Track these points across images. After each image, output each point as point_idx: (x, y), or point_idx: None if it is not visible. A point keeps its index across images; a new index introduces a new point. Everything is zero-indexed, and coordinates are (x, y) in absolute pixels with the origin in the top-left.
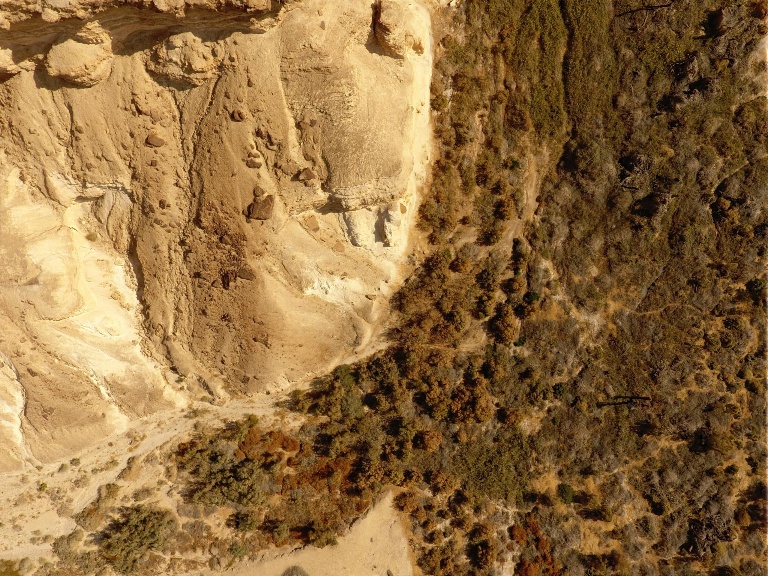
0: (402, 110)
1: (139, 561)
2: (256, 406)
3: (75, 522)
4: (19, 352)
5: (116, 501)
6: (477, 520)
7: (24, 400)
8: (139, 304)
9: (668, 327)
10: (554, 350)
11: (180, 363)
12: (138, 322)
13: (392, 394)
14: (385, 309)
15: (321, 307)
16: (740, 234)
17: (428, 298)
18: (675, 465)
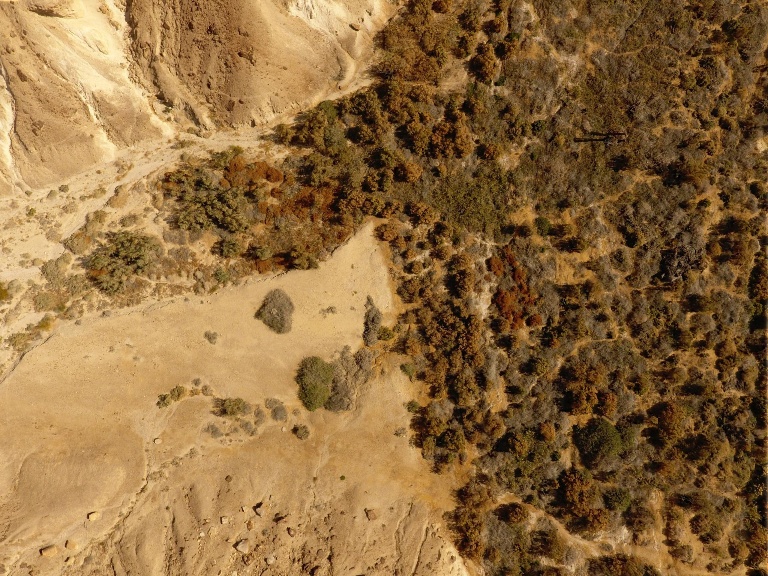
0: None
1: (125, 283)
2: (241, 139)
3: (63, 246)
4: (9, 47)
5: (103, 227)
6: (456, 252)
7: (14, 115)
8: (127, 26)
9: (645, 67)
10: (533, 86)
11: (167, 86)
12: (126, 46)
13: (374, 122)
14: (369, 47)
15: (305, 32)
16: None
17: (411, 32)
18: (649, 197)
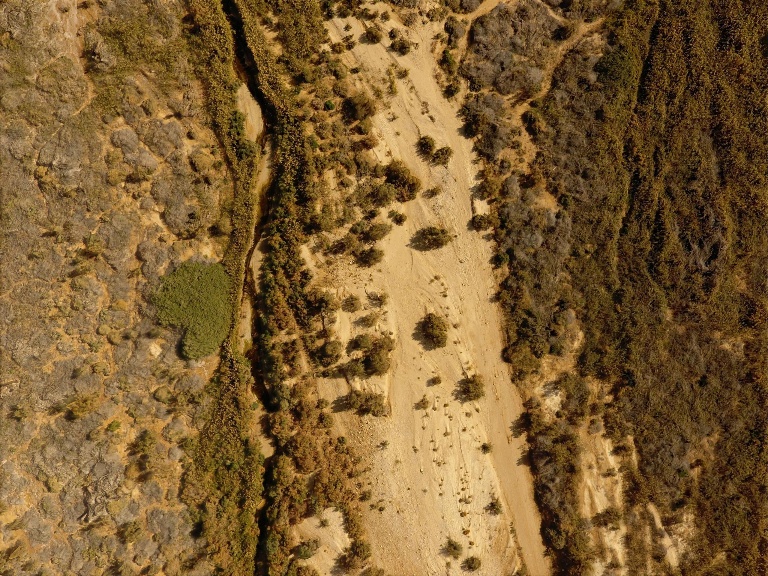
0: None
1: None
2: None
3: None
4: None
5: None
6: None
7: None
8: None
9: (19, 306)
10: None
11: None
12: None
13: None
14: None
15: None
16: (65, 196)
17: None
18: (54, 439)
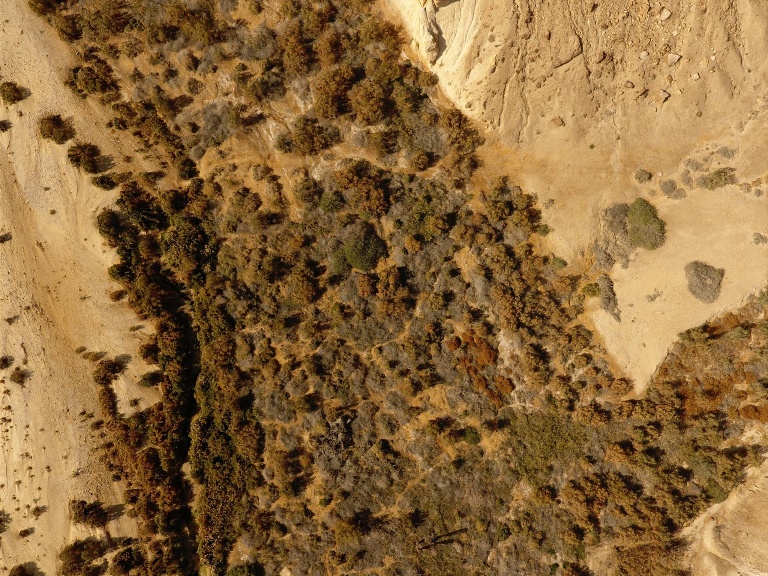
0: None
1: None
2: None
3: None
4: None
5: None
6: (547, 388)
7: None
8: None
9: None
10: (523, 574)
11: None
12: None
13: None
14: (697, 569)
15: None
16: None
17: None
18: (380, 493)
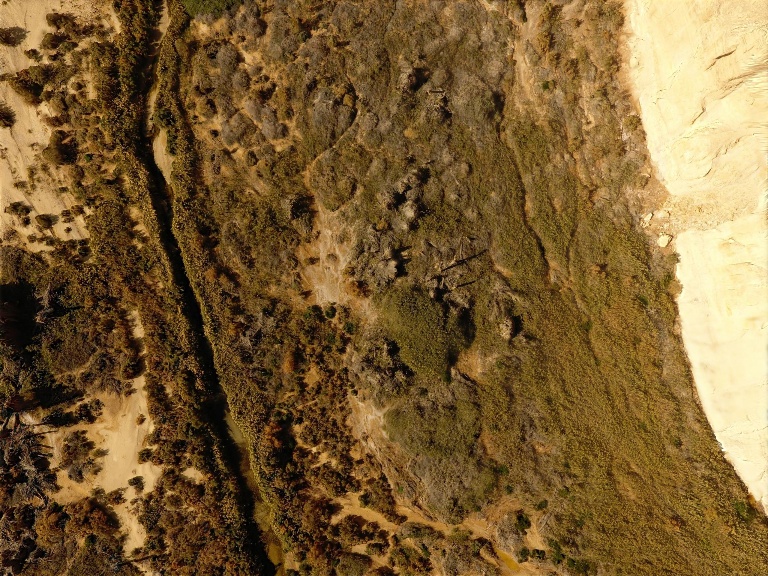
0: (726, 2)
1: None
2: None
3: None
4: None
5: None
6: None
7: None
8: None
9: None
10: None
11: None
12: None
13: None
14: None
15: None
16: (328, 78)
17: None
18: None
